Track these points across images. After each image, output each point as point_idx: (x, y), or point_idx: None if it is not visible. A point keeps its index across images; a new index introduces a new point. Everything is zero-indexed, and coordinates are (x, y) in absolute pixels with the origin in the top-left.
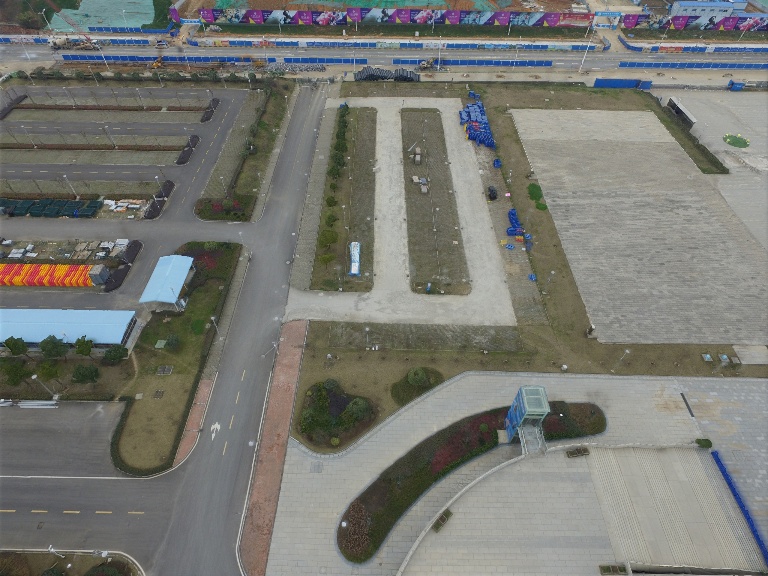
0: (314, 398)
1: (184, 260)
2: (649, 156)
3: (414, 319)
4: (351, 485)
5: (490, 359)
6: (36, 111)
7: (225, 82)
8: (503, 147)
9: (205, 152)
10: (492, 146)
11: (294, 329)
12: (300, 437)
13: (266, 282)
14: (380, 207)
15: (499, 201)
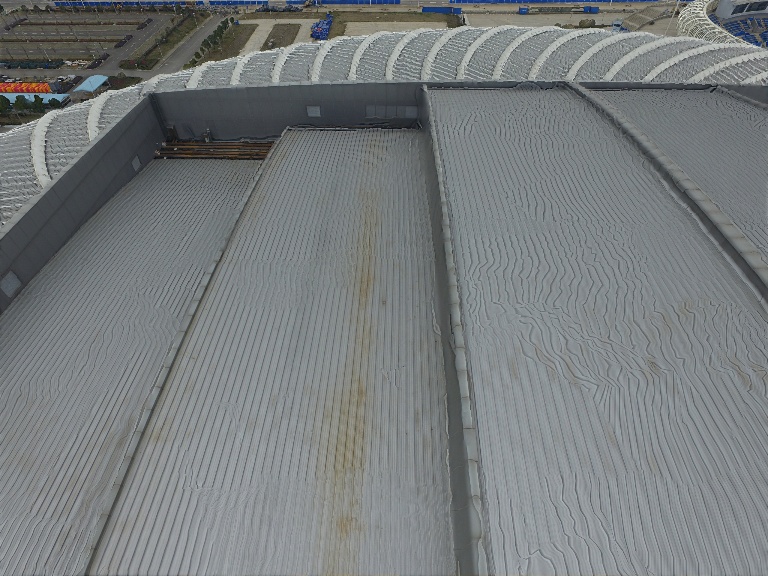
0: None
1: (102, 77)
2: None
3: None
4: None
5: None
6: (31, 26)
7: (160, 11)
8: None
9: (134, 42)
10: None
11: None
12: None
13: None
14: None
15: None
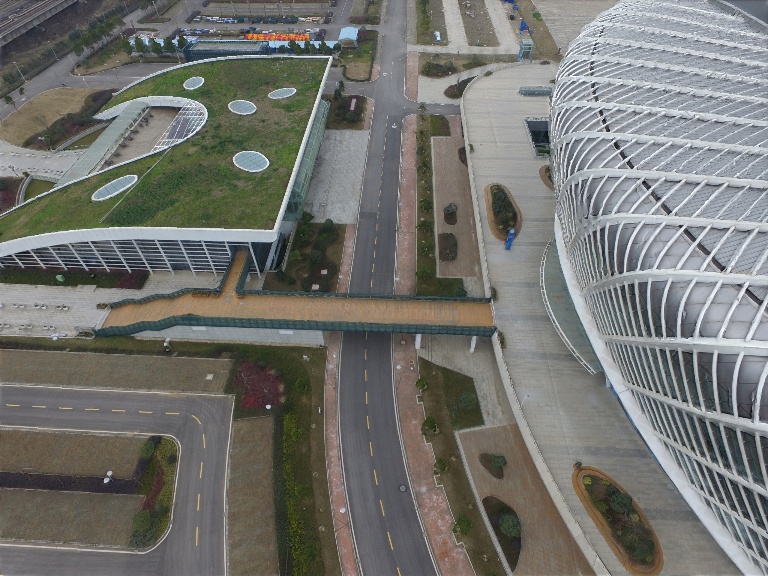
0: (428, 65)
1: (354, 29)
2: (607, 3)
3: (471, 53)
4: (448, 84)
5: None
6: None
7: None
8: (519, 1)
9: (344, 3)
10: (513, 2)
11: (412, 53)
12: (423, 75)
13: (394, 42)
14: (448, 22)
15: (516, 20)
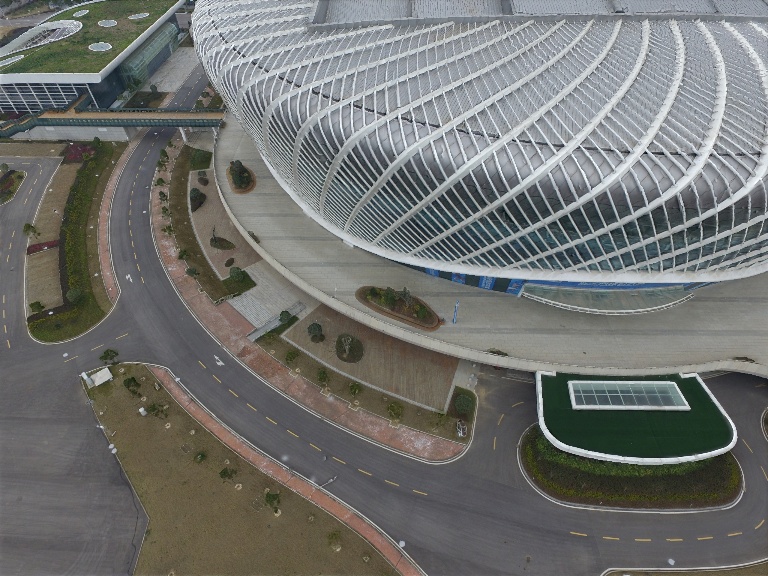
0: None
1: None
2: None
3: None
4: None
5: None
6: None
7: None
8: None
9: None
10: None
11: None
12: None
13: None
14: None
15: None
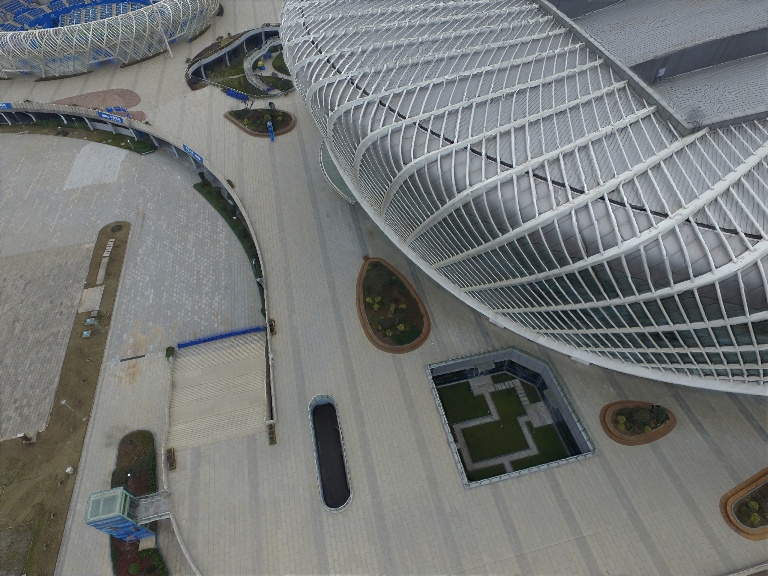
0: None
1: None
2: None
3: None
4: None
5: (37, 570)
6: None
7: None
8: None
9: None
10: None
11: None
12: None
13: None
14: None
15: None
